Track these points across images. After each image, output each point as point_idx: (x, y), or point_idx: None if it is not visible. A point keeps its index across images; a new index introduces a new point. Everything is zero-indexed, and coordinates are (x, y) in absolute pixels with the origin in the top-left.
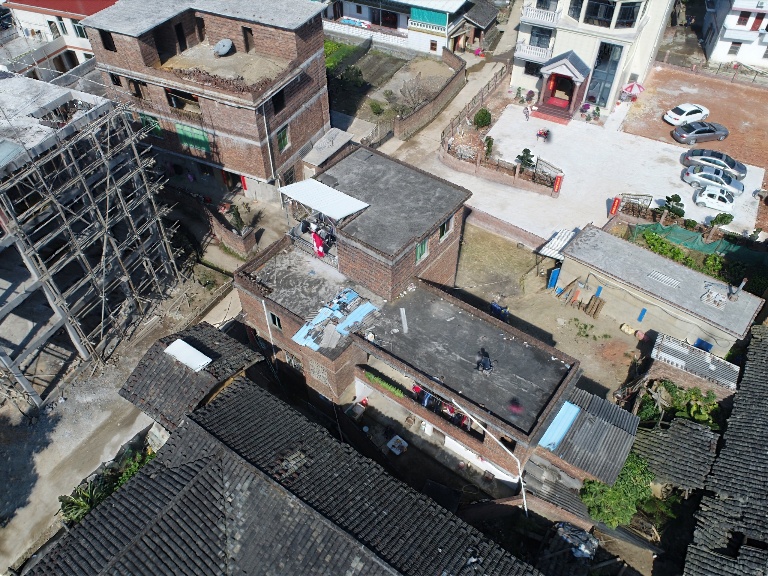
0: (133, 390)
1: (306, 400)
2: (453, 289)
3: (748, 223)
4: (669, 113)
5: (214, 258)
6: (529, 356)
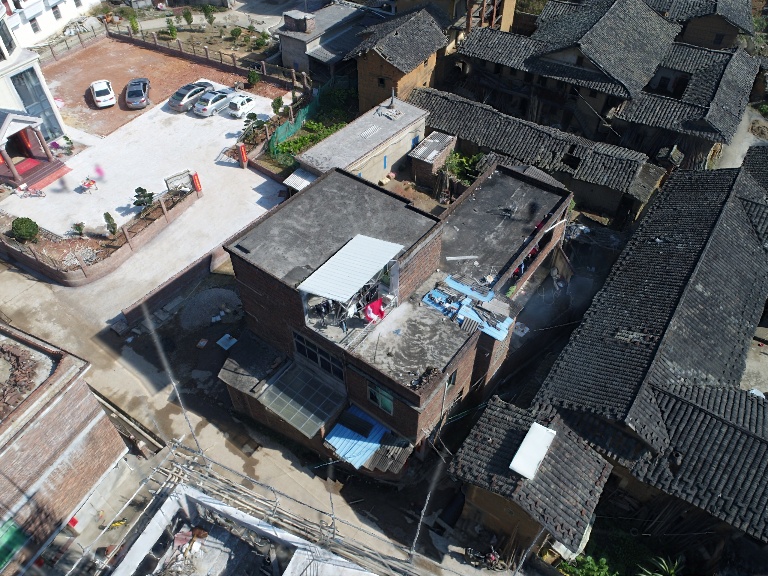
0: (572, 529)
1: (474, 412)
2: None
3: (269, 102)
4: (101, 99)
5: None
6: (490, 189)
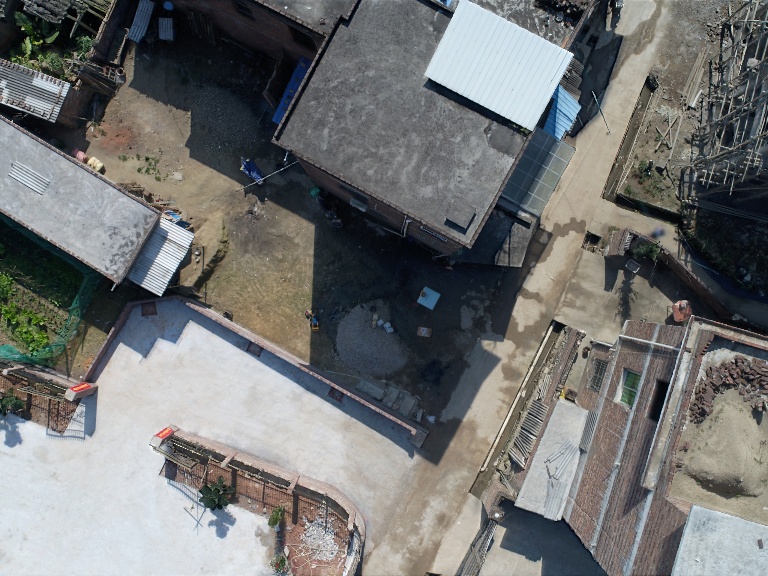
0: None
1: None
2: (317, 217)
3: None
4: None
5: (659, 228)
6: None
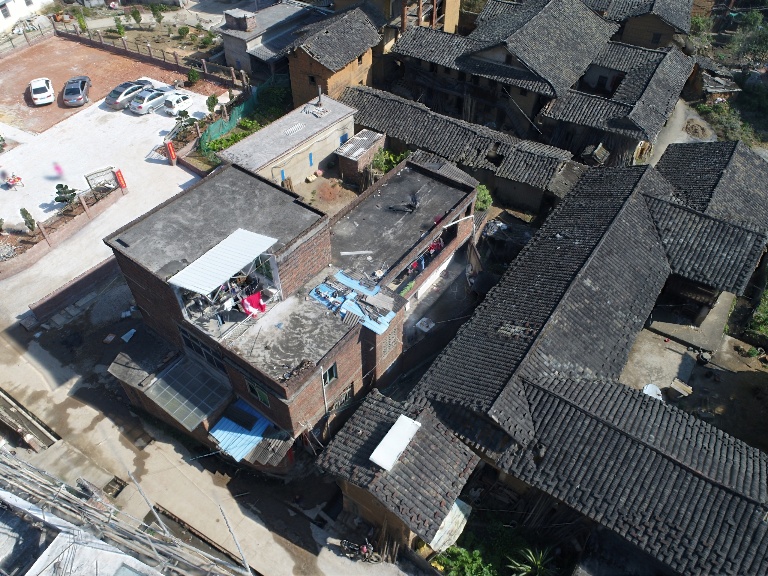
0: (428, 520)
1: None
2: None
3: None
4: (38, 97)
5: None
6: (397, 185)
